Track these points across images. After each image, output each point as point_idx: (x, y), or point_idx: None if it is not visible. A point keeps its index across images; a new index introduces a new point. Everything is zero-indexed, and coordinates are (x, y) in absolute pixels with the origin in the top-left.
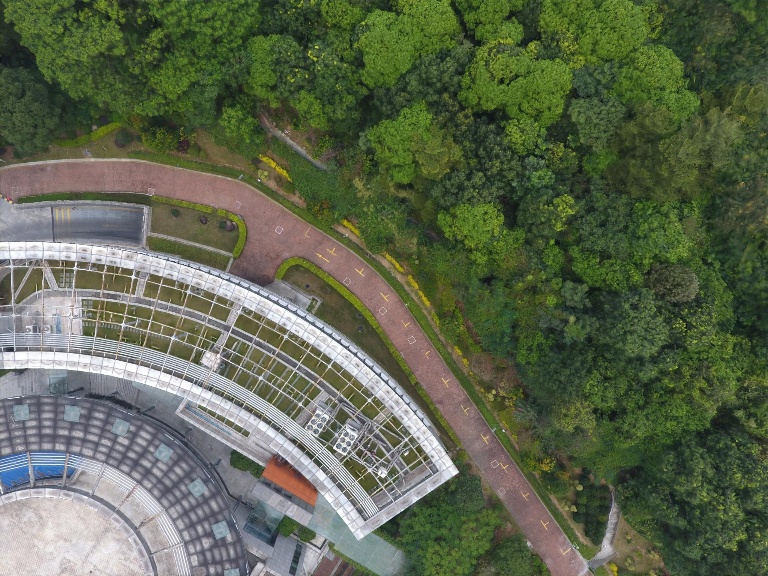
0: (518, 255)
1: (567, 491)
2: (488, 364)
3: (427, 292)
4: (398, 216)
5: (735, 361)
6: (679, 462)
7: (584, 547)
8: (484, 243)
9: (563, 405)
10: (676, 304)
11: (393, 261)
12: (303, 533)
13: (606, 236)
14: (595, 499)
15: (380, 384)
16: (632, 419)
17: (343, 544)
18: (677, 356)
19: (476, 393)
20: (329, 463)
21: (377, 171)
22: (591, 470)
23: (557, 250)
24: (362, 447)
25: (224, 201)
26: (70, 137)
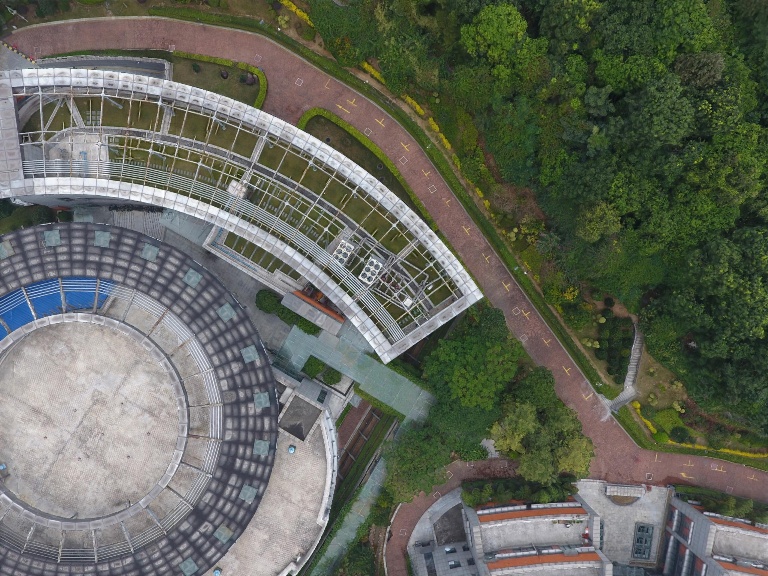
0: (541, 63)
1: (590, 320)
2: (511, 193)
3: (448, 134)
4: (419, 47)
5: (760, 153)
6: (704, 259)
7: (607, 387)
8: (507, 53)
9: (588, 210)
10: (701, 88)
11: (414, 103)
12: (329, 374)
13: (630, 31)
14: (618, 331)
15: (404, 209)
16: (657, 219)
17: (368, 384)
18: (702, 148)
19: (497, 236)
20: (355, 288)
21: None
22: (615, 292)
23: (580, 58)
24: (387, 272)
25: (244, 55)
26: None
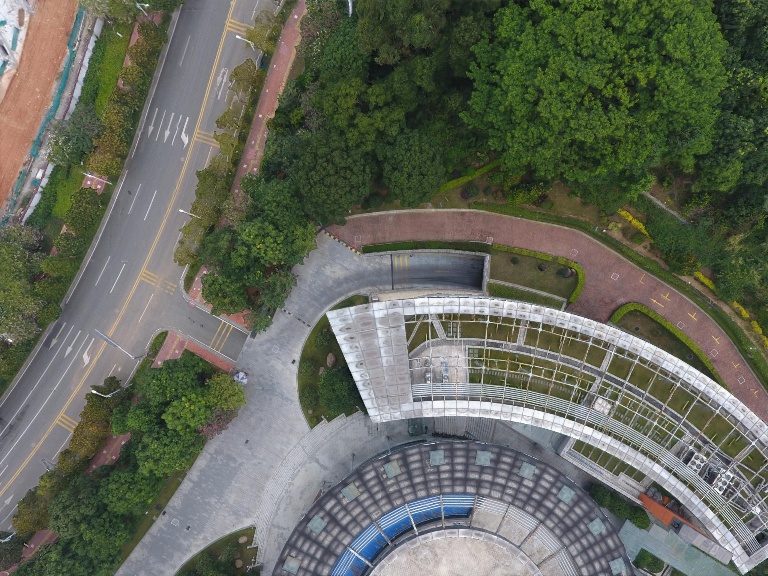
0: None
1: None
2: None
3: None
4: None
5: None
6: None
7: None
8: None
9: None
10: None
11: (741, 308)
12: (655, 565)
13: None
14: None
15: (764, 428)
16: None
17: (694, 575)
18: None
19: None
20: (716, 502)
21: (764, 229)
22: None
23: None
24: (746, 487)
25: (561, 249)
26: None
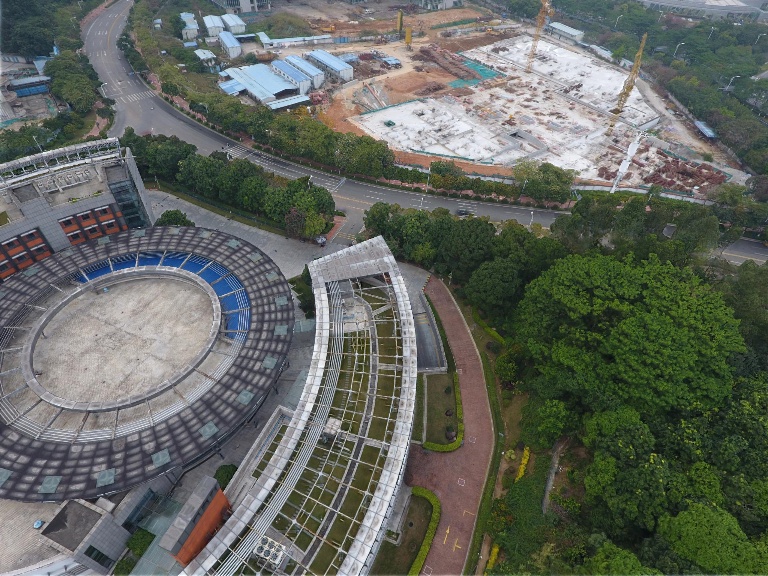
0: None
1: None
2: None
3: None
4: None
5: None
6: None
7: None
8: None
9: None
10: None
11: None
12: (127, 564)
13: None
14: None
15: None
16: None
17: None
18: None
19: None
20: (223, 571)
21: (572, 567)
22: None
23: None
24: None
25: (471, 428)
26: (481, 316)
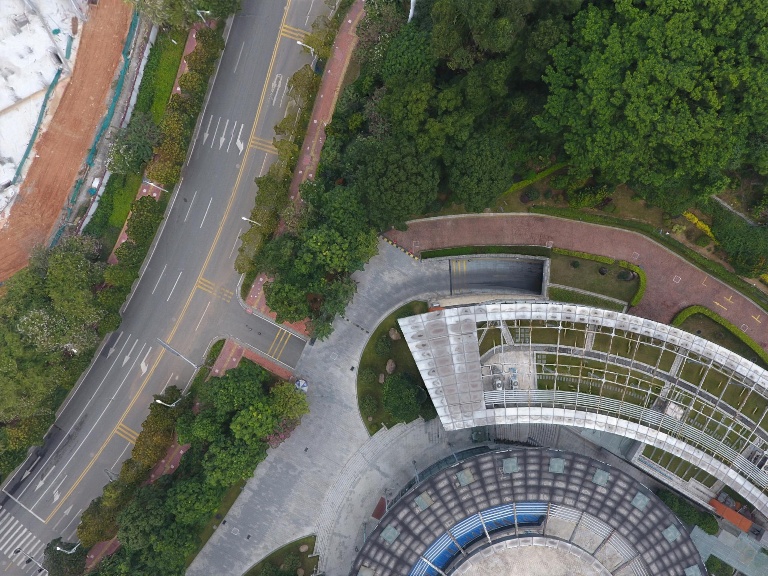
0: None
1: None
2: None
3: None
4: None
5: None
6: None
7: None
8: None
9: None
10: None
11: None
12: (724, 571)
13: None
14: None
15: None
16: None
17: None
18: None
19: None
20: None
21: None
22: None
23: None
24: None
25: (622, 252)
26: None
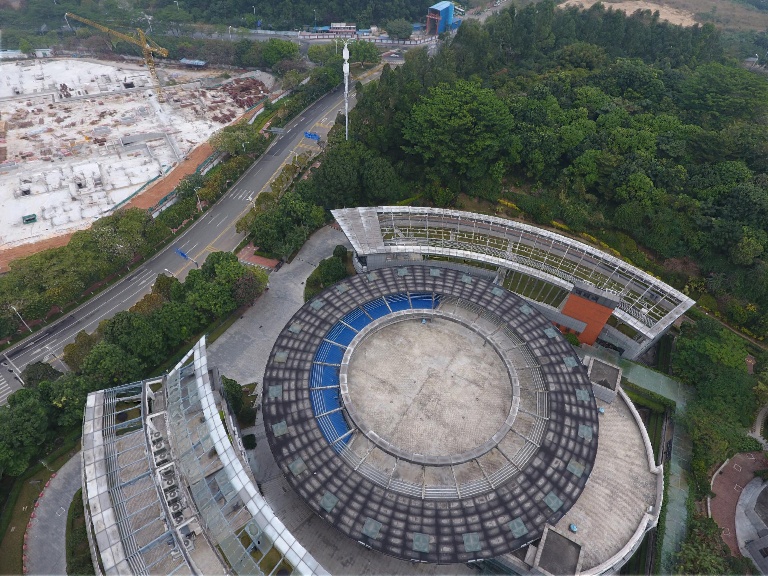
0: None
1: None
2: (676, 260)
3: (615, 248)
4: (588, 207)
5: None
6: None
7: None
8: (647, 193)
9: (737, 244)
10: None
11: (589, 235)
12: None
13: None
14: None
15: (619, 261)
16: None
17: (634, 379)
18: None
19: None
20: None
21: None
22: None
23: (686, 194)
24: None
25: None
26: (385, 205)
